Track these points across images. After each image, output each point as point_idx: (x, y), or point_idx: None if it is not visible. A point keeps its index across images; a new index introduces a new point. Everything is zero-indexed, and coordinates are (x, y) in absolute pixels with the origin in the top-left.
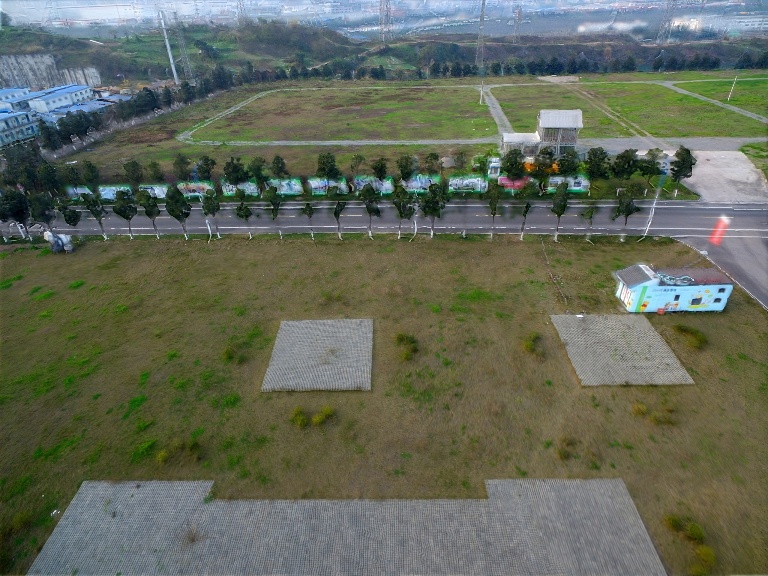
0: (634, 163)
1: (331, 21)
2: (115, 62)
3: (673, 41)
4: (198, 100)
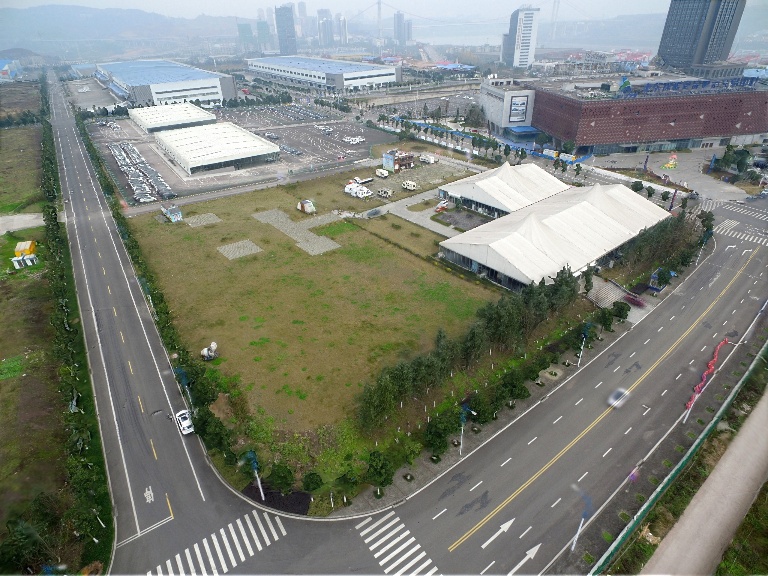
0: (53, 218)
1: None
2: None
3: None
4: None
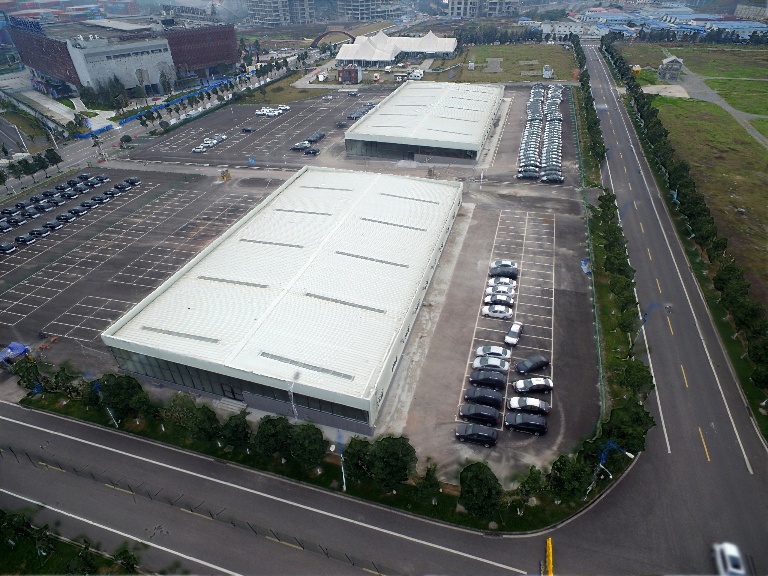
0: (622, 68)
1: None
2: None
3: None
4: None
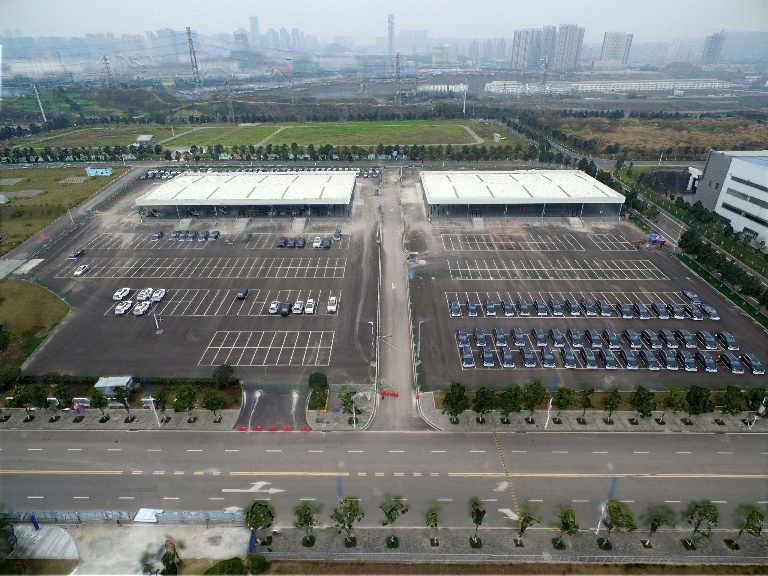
0: (143, 149)
1: (170, 87)
2: (8, 112)
3: (405, 103)
4: (42, 133)
